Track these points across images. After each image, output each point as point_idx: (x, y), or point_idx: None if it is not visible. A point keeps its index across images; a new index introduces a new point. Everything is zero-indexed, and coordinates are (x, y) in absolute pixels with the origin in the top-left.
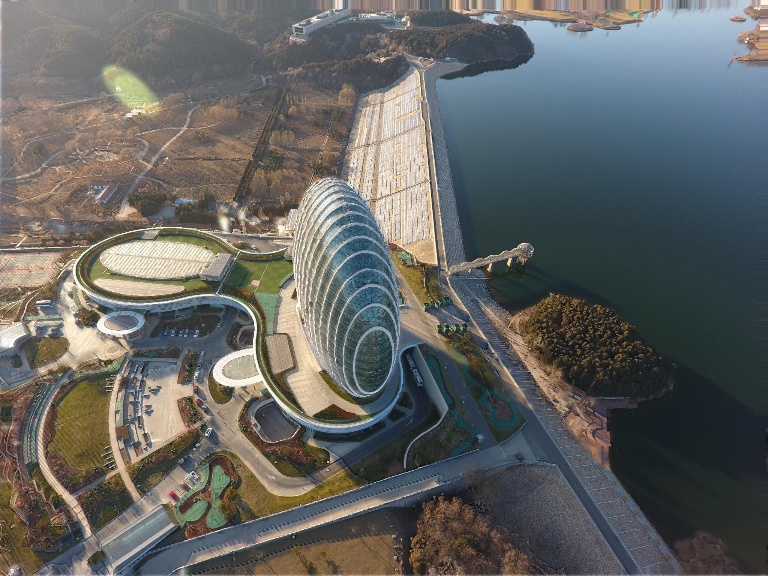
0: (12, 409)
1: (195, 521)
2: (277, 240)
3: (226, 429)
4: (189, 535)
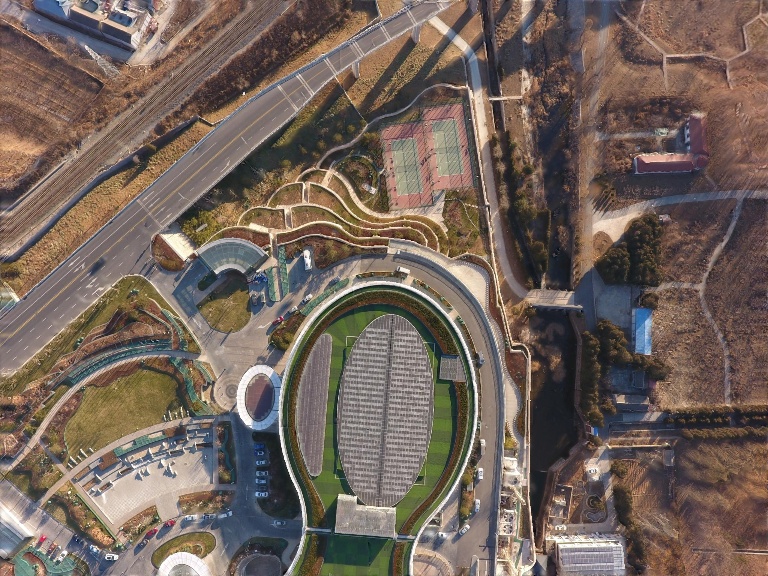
0: (132, 323)
1: (14, 574)
2: (487, 567)
3: (118, 575)
4: (2, 571)
